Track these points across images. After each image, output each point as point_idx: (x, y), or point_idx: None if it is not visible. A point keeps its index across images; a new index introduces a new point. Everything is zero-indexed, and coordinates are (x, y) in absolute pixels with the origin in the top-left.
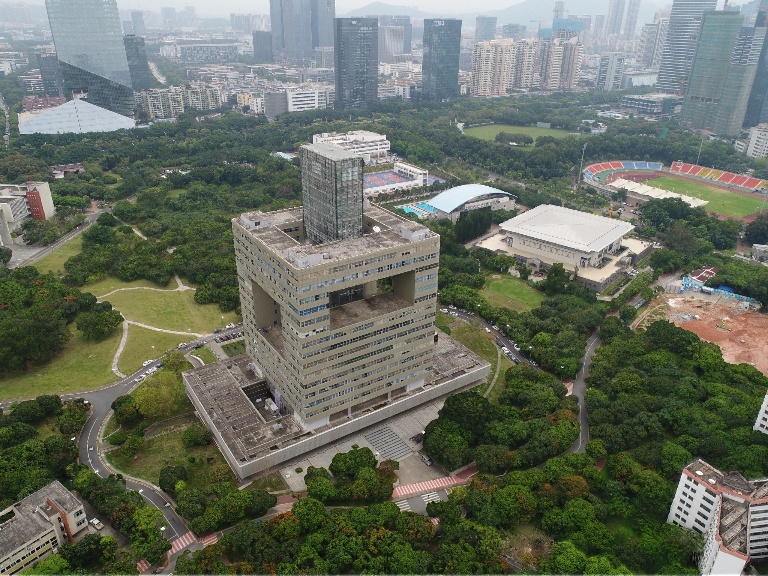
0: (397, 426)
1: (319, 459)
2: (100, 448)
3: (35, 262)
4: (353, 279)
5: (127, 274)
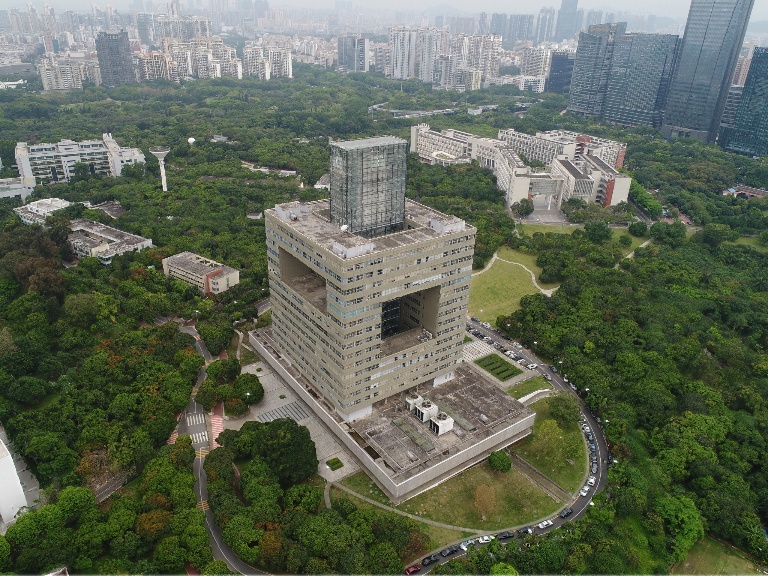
0: (309, 422)
1: (270, 378)
2: None
3: (537, 225)
4: (290, 247)
5: (539, 258)
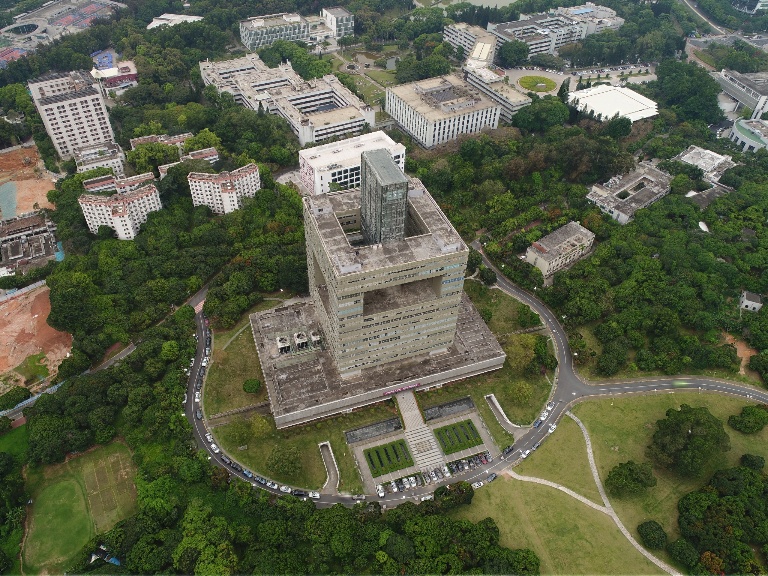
0: None
1: None
2: (548, 329)
3: None
4: None
5: None
